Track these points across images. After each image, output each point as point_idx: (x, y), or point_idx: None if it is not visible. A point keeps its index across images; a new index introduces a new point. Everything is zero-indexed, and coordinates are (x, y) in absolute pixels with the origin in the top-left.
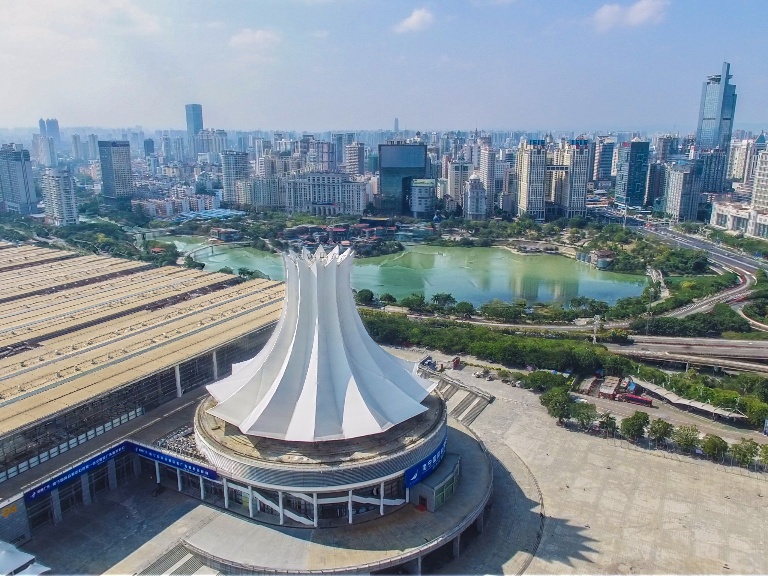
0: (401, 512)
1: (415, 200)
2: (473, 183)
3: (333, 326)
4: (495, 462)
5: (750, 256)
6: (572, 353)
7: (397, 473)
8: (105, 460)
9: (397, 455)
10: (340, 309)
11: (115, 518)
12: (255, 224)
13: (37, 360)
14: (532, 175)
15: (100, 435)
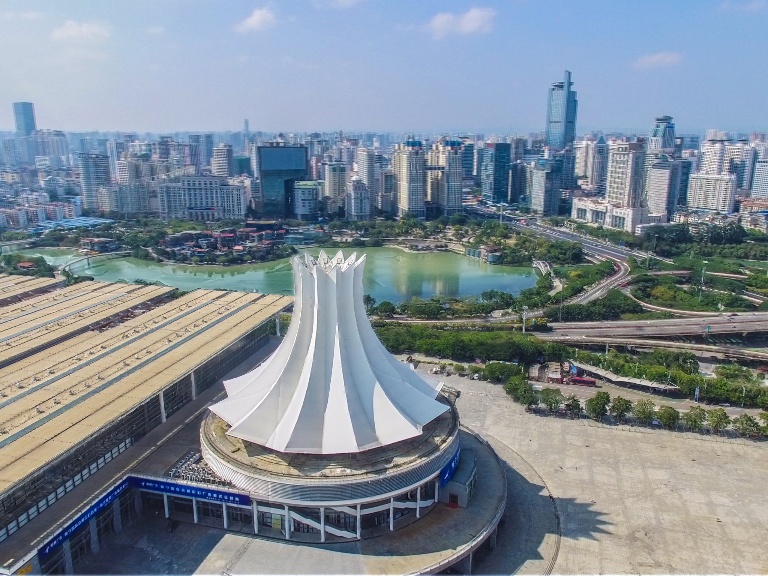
0: (435, 512)
1: (299, 202)
2: (356, 184)
3: (351, 333)
4: None
5: (614, 245)
6: (517, 343)
7: (434, 474)
8: (111, 500)
9: (434, 456)
10: (355, 315)
11: (136, 562)
12: (130, 232)
13: None
14: (412, 175)
15: (94, 473)
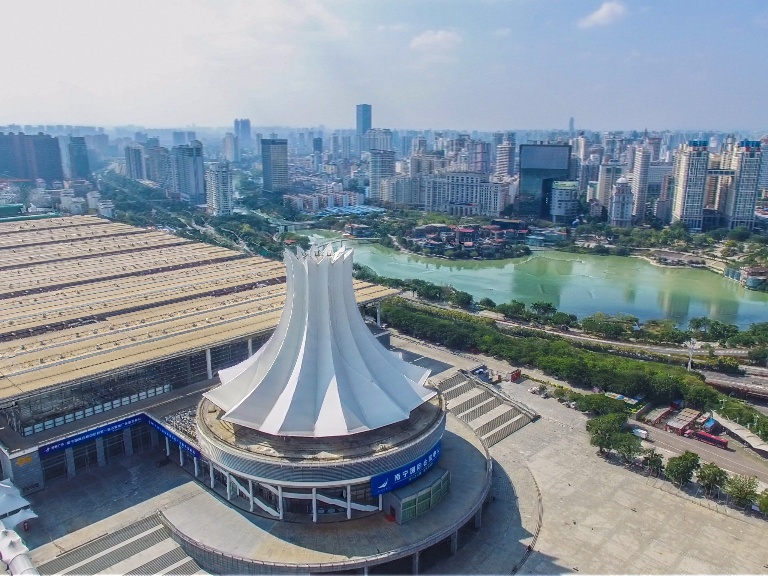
0: (369, 519)
1: (555, 203)
2: (620, 187)
3: (324, 324)
4: (506, 484)
5: None
6: (645, 378)
7: (362, 478)
8: (121, 428)
9: (362, 460)
10: (334, 308)
11: (117, 481)
12: (389, 221)
13: (91, 333)
14: (689, 180)
15: (125, 405)
